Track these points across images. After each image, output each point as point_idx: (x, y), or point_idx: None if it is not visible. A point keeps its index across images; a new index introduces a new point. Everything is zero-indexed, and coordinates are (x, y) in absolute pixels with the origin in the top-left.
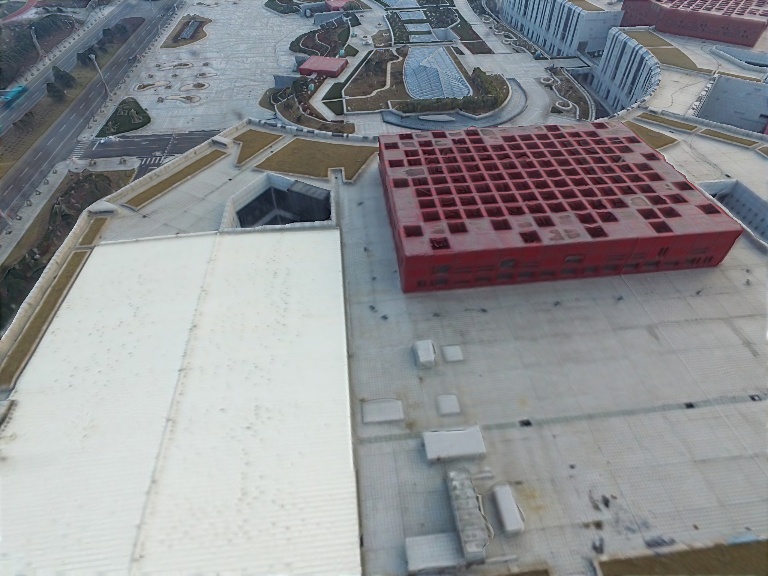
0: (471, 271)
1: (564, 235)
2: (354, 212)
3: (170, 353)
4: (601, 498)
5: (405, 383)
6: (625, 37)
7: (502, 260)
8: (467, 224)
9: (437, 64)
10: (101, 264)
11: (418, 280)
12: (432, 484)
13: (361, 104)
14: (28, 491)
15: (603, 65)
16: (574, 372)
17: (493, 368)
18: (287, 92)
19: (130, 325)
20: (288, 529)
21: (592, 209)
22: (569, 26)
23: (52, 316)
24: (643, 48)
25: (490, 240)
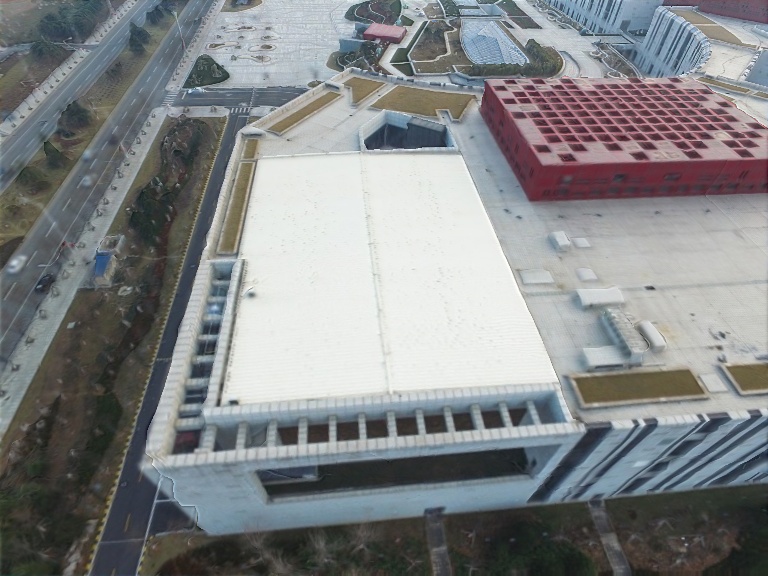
0: (588, 183)
1: (667, 156)
2: (468, 143)
3: (357, 233)
4: (719, 333)
5: (549, 260)
6: (672, 15)
7: (616, 174)
8: (585, 145)
9: (492, 35)
10: (269, 172)
11: (544, 189)
12: (591, 320)
13: (428, 67)
14: (287, 312)
15: (647, 42)
16: (681, 257)
17: (616, 253)
18: (357, 54)
19: (315, 214)
20: (492, 341)
21: (685, 139)
22: (613, 5)
23: (246, 206)
24: (691, 24)
25: (607, 157)
